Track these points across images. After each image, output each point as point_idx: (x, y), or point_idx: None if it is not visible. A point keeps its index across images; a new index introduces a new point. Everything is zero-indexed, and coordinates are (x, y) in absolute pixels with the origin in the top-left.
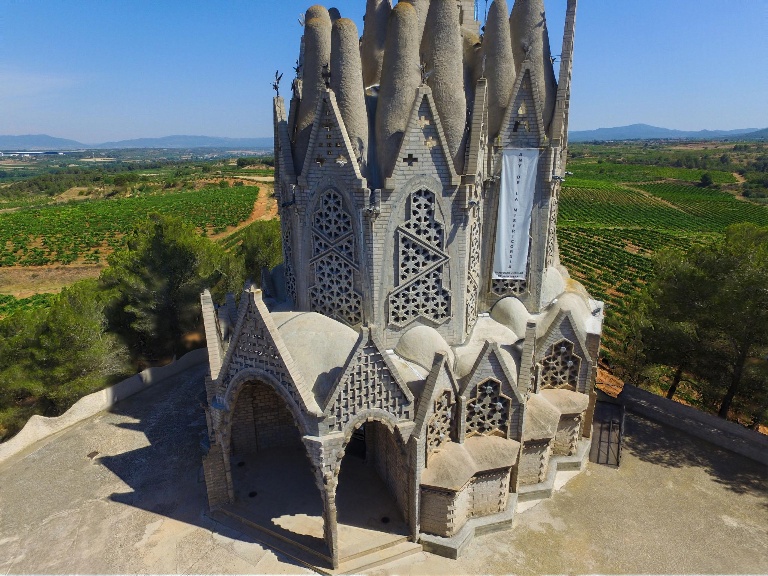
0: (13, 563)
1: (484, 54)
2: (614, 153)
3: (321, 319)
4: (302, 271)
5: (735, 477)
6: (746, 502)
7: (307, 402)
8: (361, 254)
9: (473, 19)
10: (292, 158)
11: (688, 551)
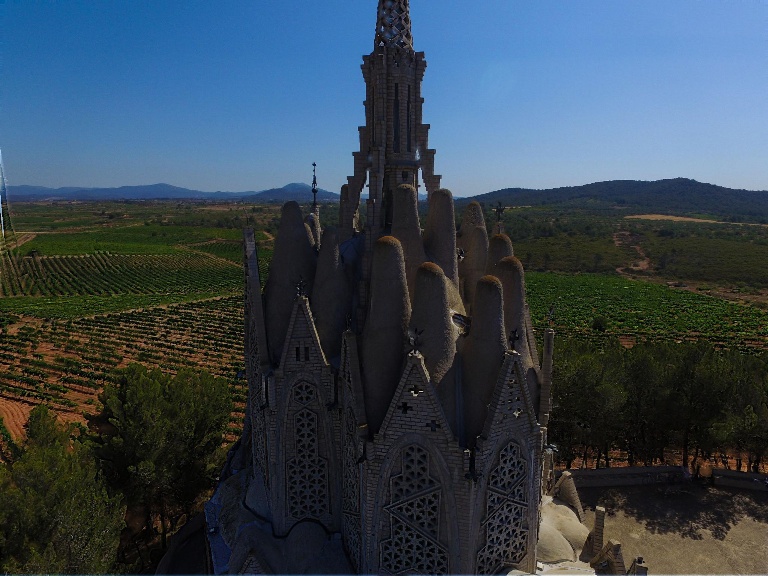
0: None
1: (477, 268)
2: (182, 222)
3: None
4: (471, 538)
5: (600, 505)
6: (622, 518)
7: None
8: (530, 491)
9: None
10: (446, 419)
11: (655, 570)
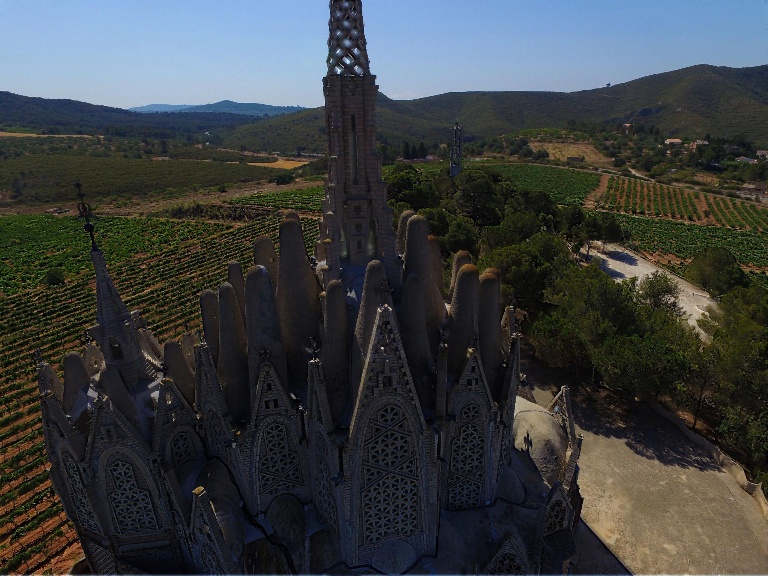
0: (689, 574)
1: None
2: None
3: (526, 402)
4: None
5: None
6: None
7: None
8: None
9: None
10: None
11: None
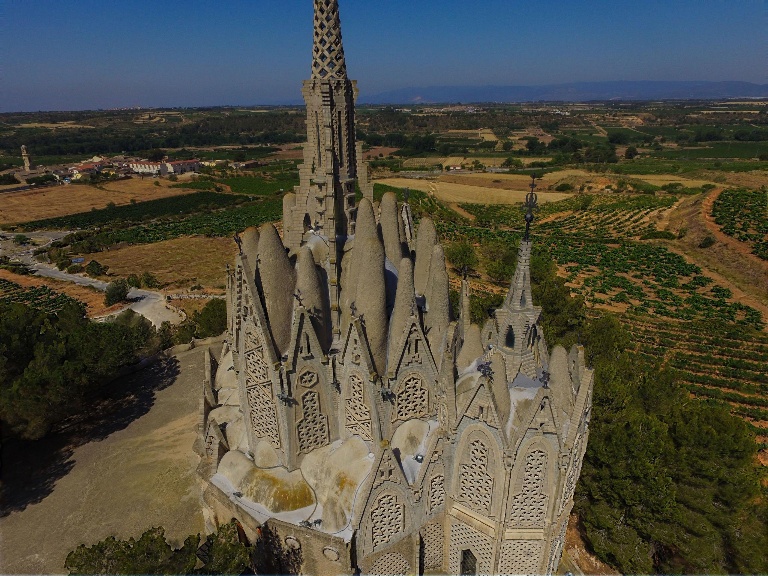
0: None
1: None
2: None
3: None
4: None
5: None
6: None
7: (220, 360)
8: None
9: (329, 234)
10: None
11: None
